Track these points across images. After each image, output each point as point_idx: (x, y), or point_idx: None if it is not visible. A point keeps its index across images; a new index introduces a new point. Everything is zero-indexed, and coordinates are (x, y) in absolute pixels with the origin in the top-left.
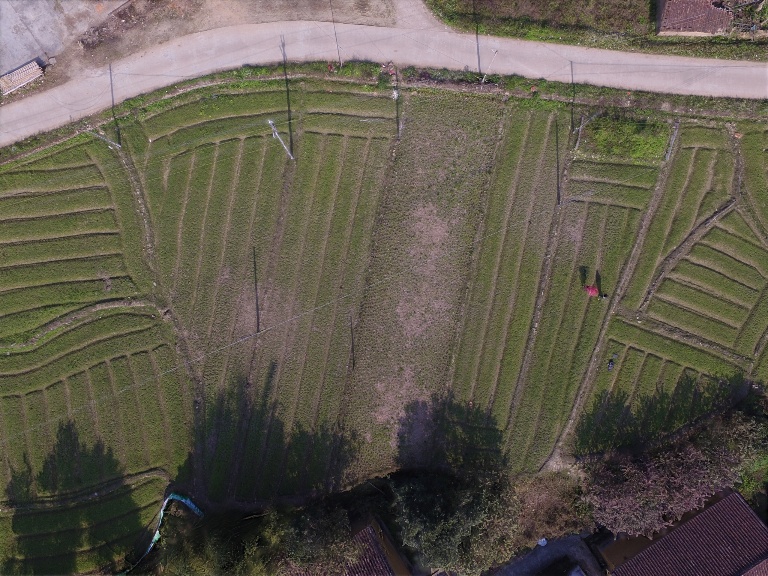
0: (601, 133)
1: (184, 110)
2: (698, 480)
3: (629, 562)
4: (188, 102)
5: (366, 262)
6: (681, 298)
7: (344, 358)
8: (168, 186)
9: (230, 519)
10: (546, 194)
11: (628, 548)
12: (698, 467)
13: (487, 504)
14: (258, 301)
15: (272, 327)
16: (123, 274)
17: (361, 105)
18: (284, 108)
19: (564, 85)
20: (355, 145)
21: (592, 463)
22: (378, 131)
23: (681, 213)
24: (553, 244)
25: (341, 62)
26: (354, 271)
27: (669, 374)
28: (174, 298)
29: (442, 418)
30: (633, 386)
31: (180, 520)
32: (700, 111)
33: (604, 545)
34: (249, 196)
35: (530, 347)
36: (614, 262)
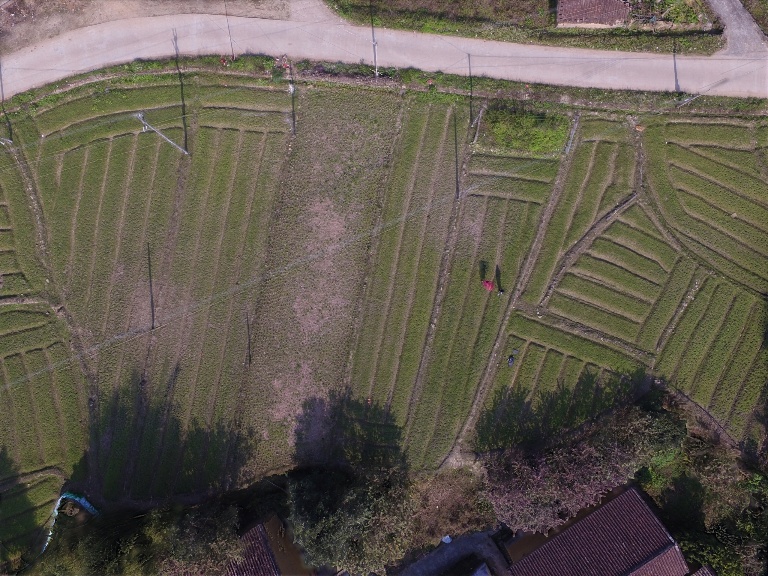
0: (499, 126)
1: (76, 105)
2: (591, 476)
3: (525, 559)
4: (81, 97)
5: (262, 258)
6: (582, 293)
7: (240, 355)
8: (61, 182)
9: (119, 517)
10: (445, 188)
11: (528, 545)
12: (591, 463)
13: (373, 501)
14: (153, 298)
15: (167, 324)
16: (16, 271)
17: (256, 99)
18: (178, 102)
19: (461, 78)
20: (250, 140)
21: (493, 460)
22: (274, 125)
23: (582, 207)
24: (452, 239)
25: (234, 56)
26: (250, 267)
27: (570, 369)
28: (68, 295)
29: (340, 415)
30: (534, 382)
31: (70, 519)
32: (600, 104)
33: (510, 542)
34: (143, 192)
35: (429, 343)
36: (514, 257)
